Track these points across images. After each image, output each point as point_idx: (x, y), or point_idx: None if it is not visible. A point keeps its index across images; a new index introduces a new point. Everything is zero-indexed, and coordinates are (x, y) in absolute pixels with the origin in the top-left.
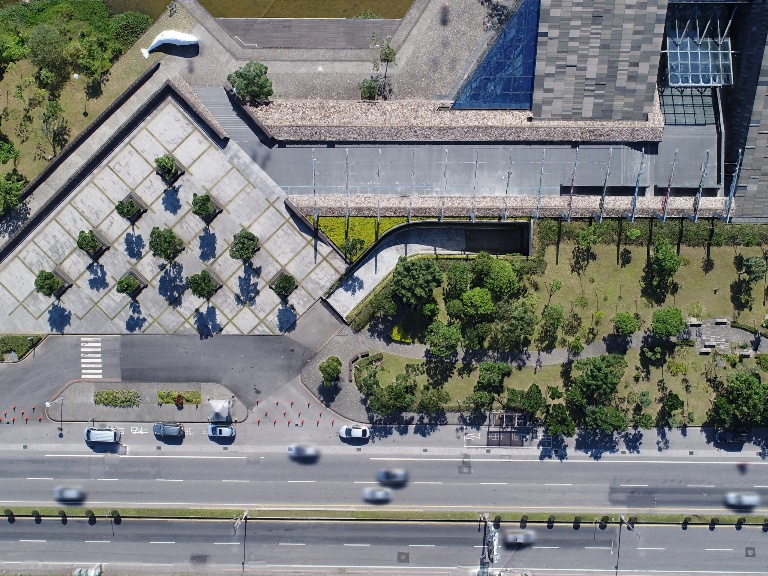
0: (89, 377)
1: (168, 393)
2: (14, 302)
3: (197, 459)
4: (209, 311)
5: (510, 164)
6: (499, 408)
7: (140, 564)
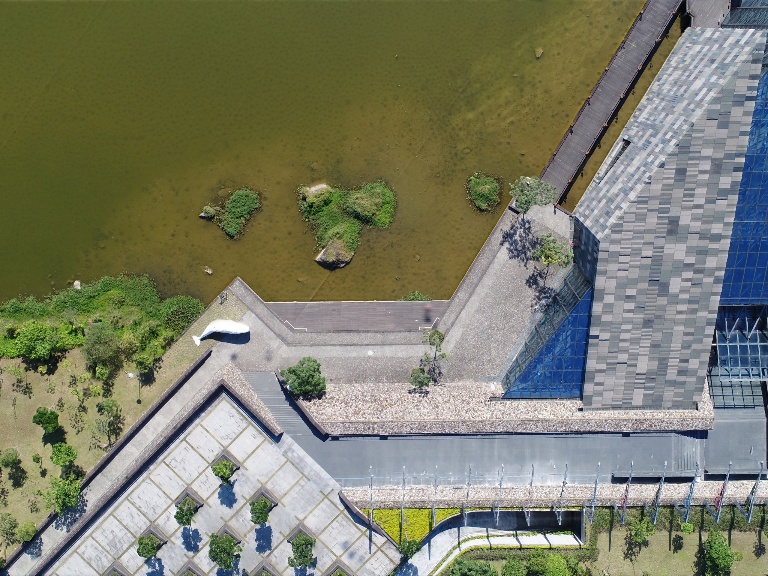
0: None
1: None
2: None
3: None
4: None
5: (565, 476)
6: None
7: None
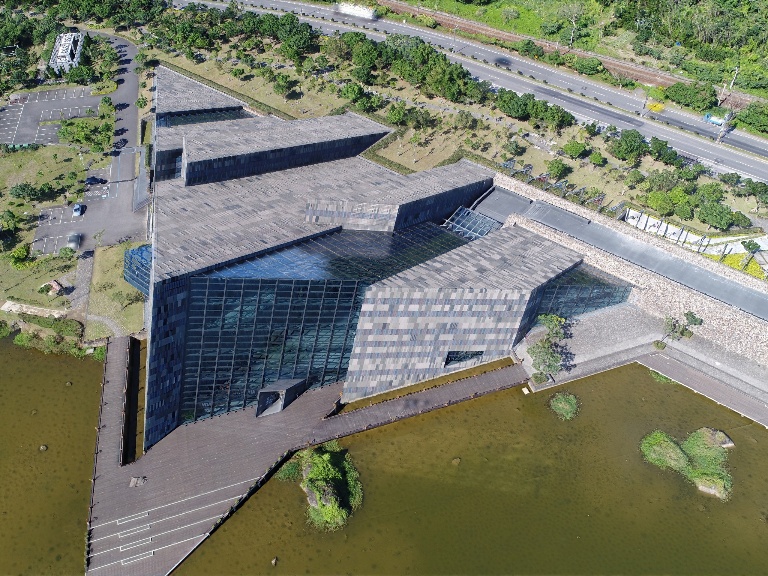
0: None
1: None
2: None
3: None
4: None
5: None
6: None
7: None
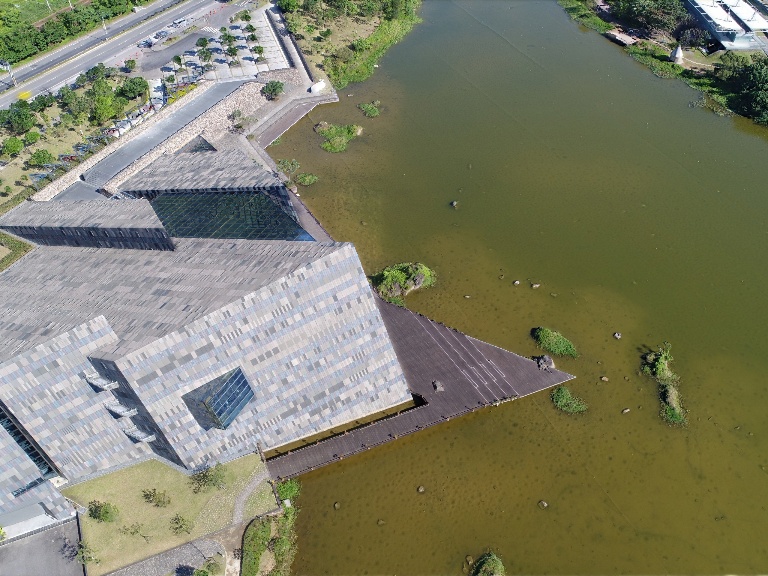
0: None
1: None
2: None
3: (143, 38)
4: None
5: None
6: (53, 103)
7: (124, 19)
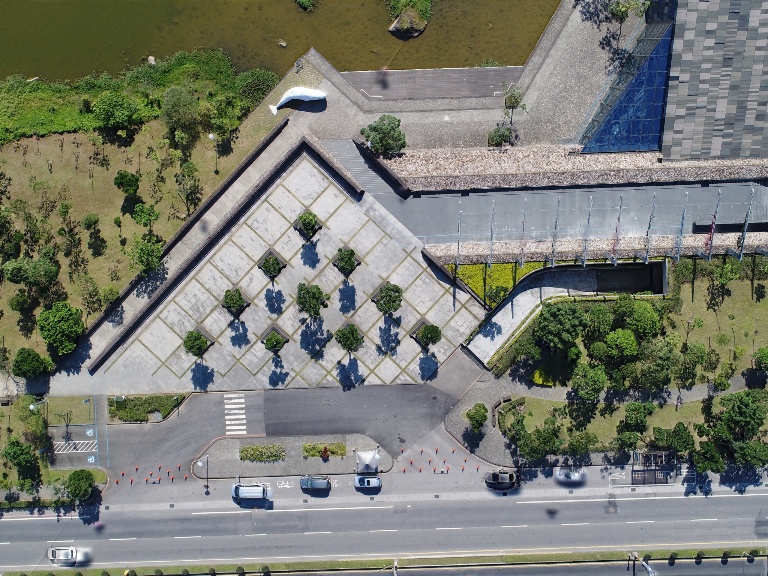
0: (234, 433)
1: (314, 446)
2: (157, 362)
3: (344, 510)
4: (351, 363)
5: (653, 208)
6: (643, 447)
7: None
